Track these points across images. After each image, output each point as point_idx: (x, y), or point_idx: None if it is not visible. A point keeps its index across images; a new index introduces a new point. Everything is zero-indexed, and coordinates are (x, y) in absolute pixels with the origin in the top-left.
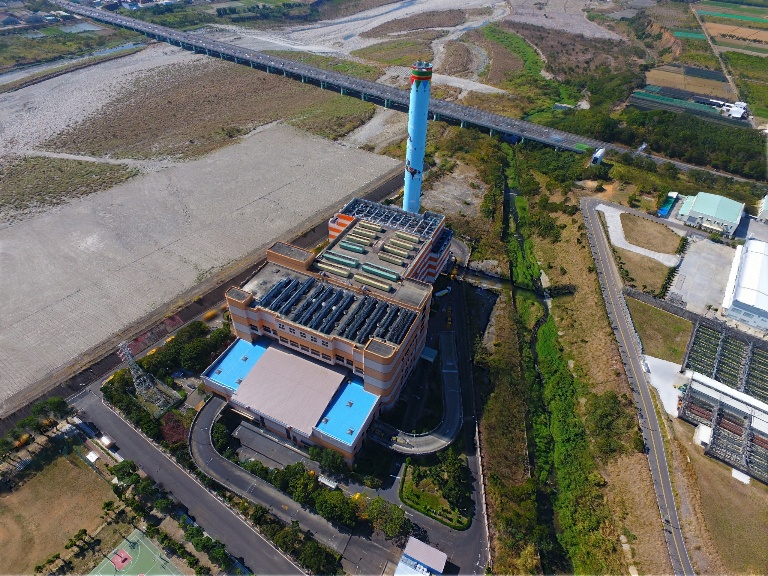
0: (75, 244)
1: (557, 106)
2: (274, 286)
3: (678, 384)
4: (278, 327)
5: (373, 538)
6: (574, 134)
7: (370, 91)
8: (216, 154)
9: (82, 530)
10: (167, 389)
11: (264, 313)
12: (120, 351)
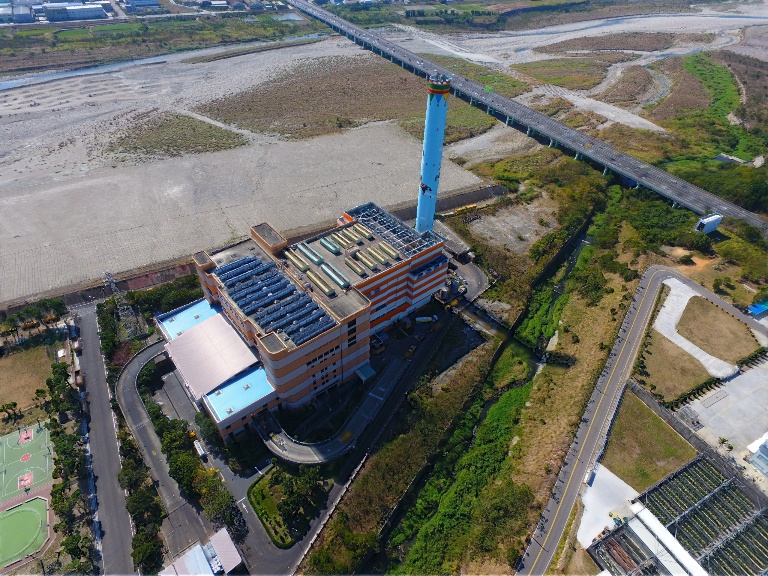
0: (164, 189)
1: (720, 157)
2: (237, 260)
3: (618, 513)
4: (220, 297)
5: (202, 514)
6: (708, 192)
7: (496, 105)
8: (316, 140)
9: (13, 402)
10: (142, 322)
11: (215, 281)
12: (131, 281)
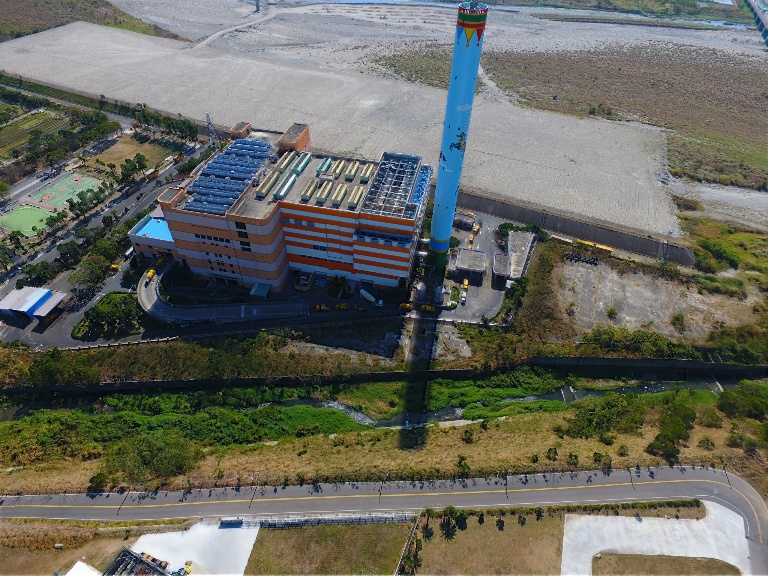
0: (364, 99)
1: None
2: None
3: (193, 571)
4: None
5: None
6: None
7: None
8: (544, 113)
9: (114, 164)
10: None
11: None
12: None
